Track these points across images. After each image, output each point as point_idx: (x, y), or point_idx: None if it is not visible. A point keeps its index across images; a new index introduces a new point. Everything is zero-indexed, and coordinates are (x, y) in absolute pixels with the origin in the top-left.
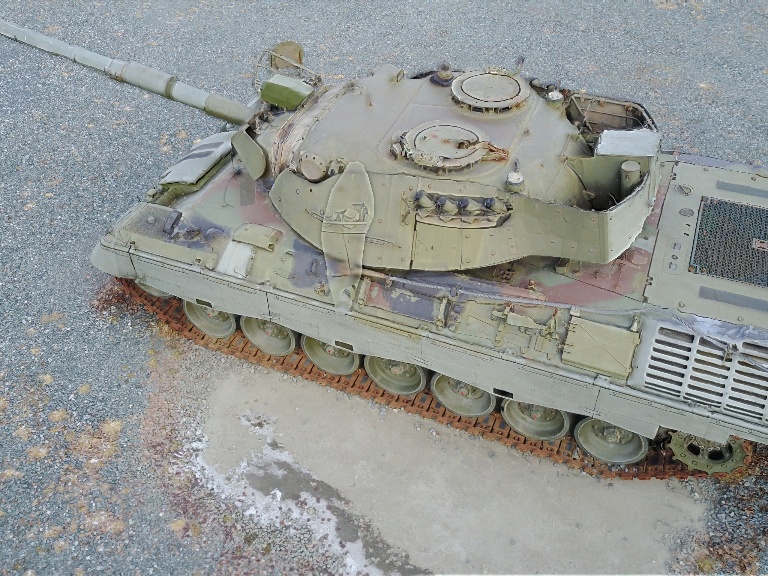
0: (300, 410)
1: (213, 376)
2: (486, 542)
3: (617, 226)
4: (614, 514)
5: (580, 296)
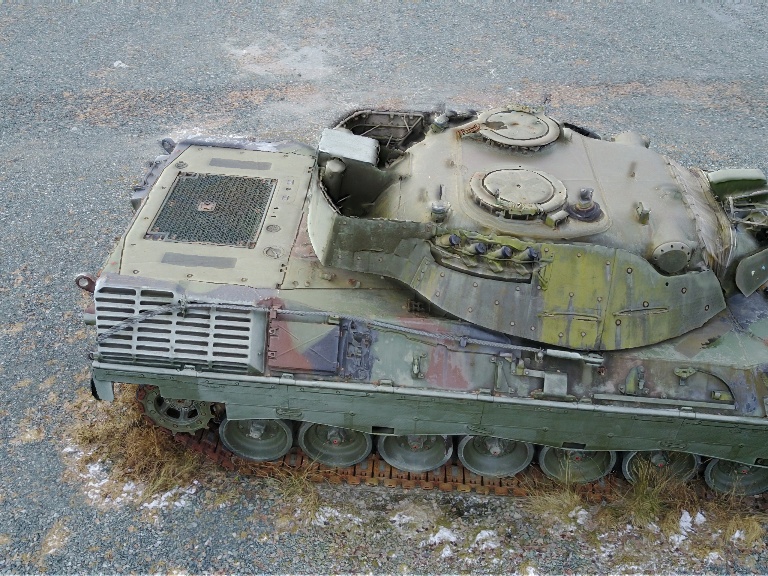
0: None
1: None
2: None
3: None
4: None
5: None
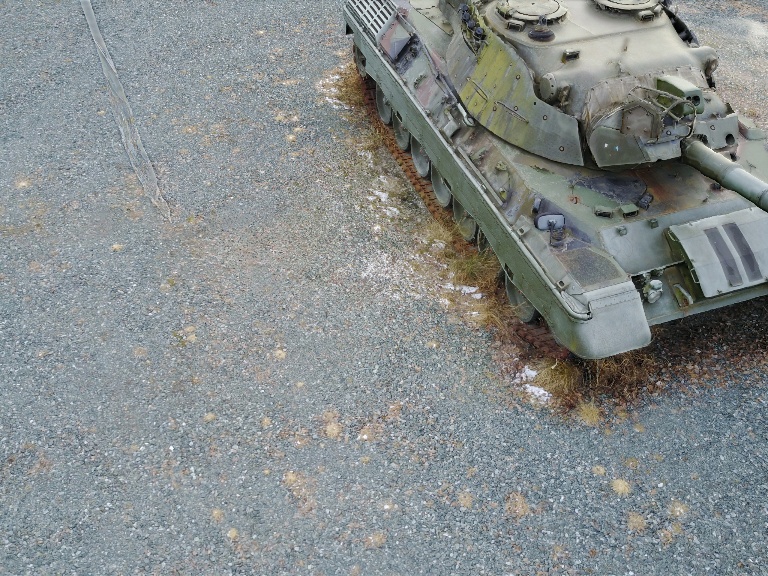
0: None
1: None
2: None
3: None
4: None
5: None
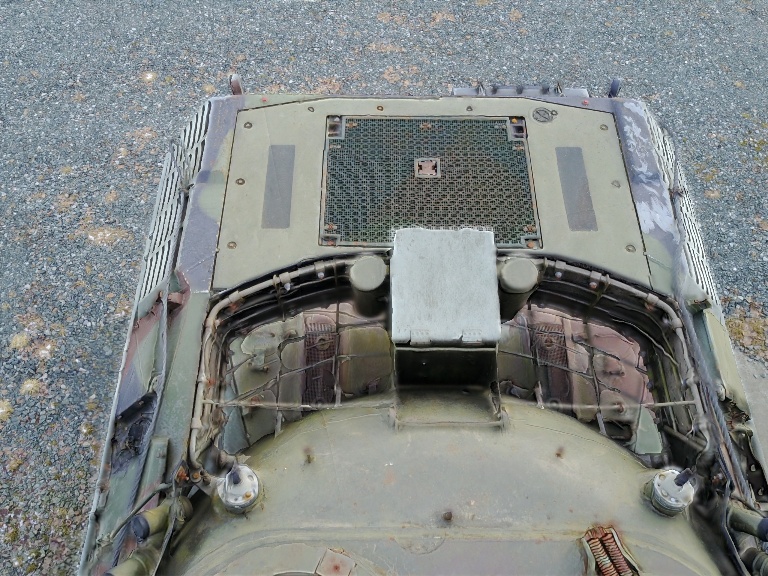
0: None
1: None
2: None
3: None
4: None
5: None
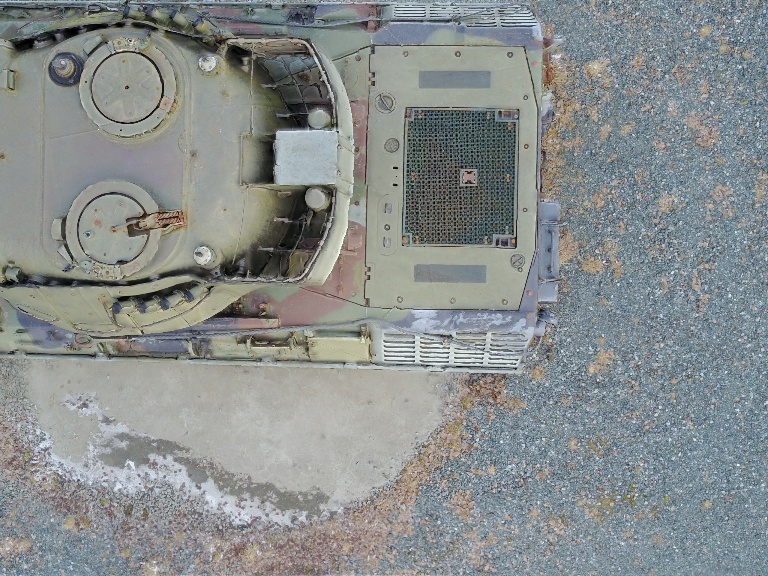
0: (111, 378)
1: (18, 370)
2: (304, 444)
3: (319, 270)
4: (395, 381)
5: (309, 311)
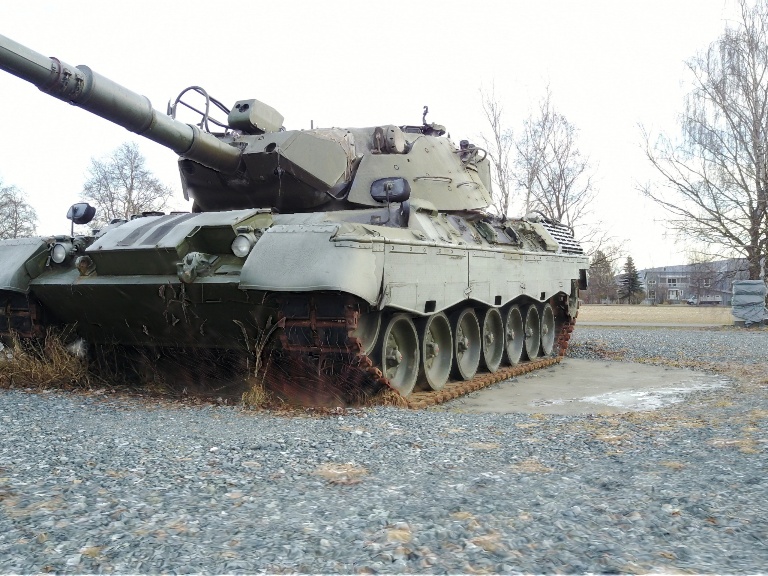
0: None
1: None
2: None
3: None
4: None
5: None
